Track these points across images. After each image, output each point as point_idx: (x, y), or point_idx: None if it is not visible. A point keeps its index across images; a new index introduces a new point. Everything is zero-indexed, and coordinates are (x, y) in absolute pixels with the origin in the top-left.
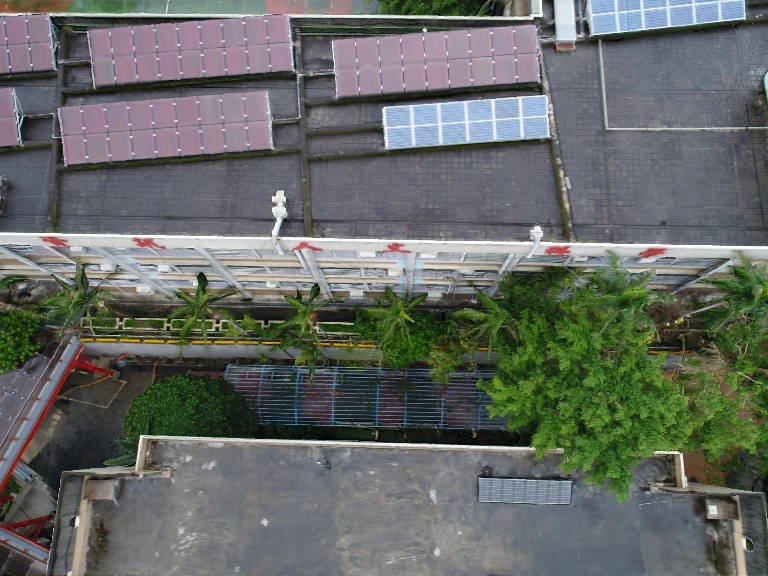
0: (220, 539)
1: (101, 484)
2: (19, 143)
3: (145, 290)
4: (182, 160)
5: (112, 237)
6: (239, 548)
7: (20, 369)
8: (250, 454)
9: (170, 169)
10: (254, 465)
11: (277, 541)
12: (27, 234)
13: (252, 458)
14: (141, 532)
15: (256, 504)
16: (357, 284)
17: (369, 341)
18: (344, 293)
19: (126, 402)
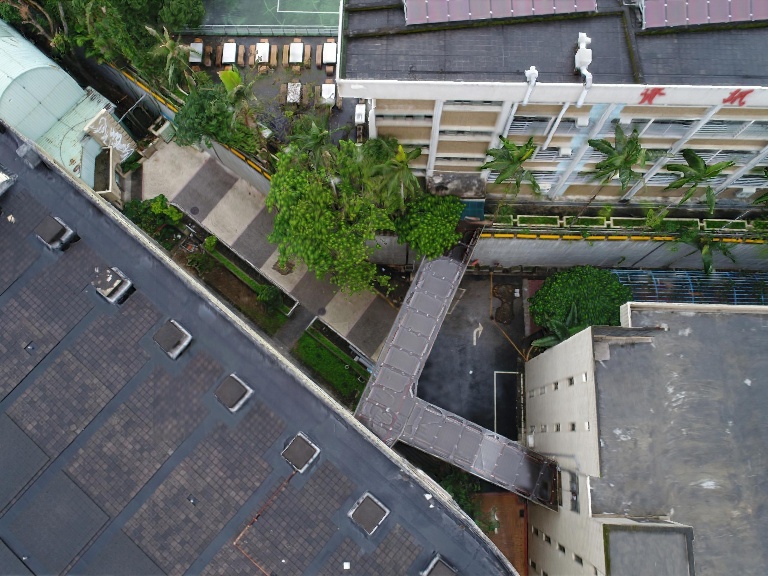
0: (709, 397)
1: (597, 346)
2: (595, 9)
3: (546, 187)
4: (749, 25)
5: (718, 88)
6: (728, 405)
7: (447, 256)
8: (722, 322)
9: (735, 34)
10: (727, 332)
11: (762, 399)
12: (638, 85)
13: (724, 325)
14: (633, 391)
15: (737, 366)
16: (764, 178)
17: (762, 235)
18: (725, 193)
19: (469, 308)
